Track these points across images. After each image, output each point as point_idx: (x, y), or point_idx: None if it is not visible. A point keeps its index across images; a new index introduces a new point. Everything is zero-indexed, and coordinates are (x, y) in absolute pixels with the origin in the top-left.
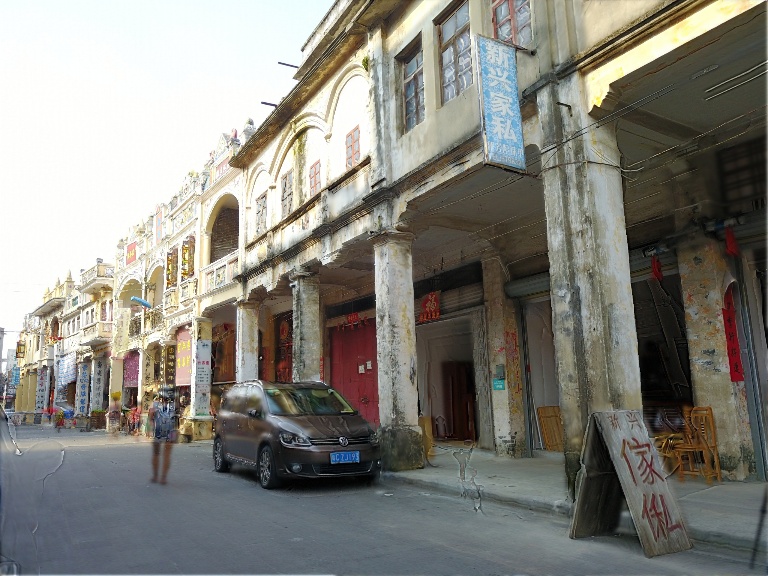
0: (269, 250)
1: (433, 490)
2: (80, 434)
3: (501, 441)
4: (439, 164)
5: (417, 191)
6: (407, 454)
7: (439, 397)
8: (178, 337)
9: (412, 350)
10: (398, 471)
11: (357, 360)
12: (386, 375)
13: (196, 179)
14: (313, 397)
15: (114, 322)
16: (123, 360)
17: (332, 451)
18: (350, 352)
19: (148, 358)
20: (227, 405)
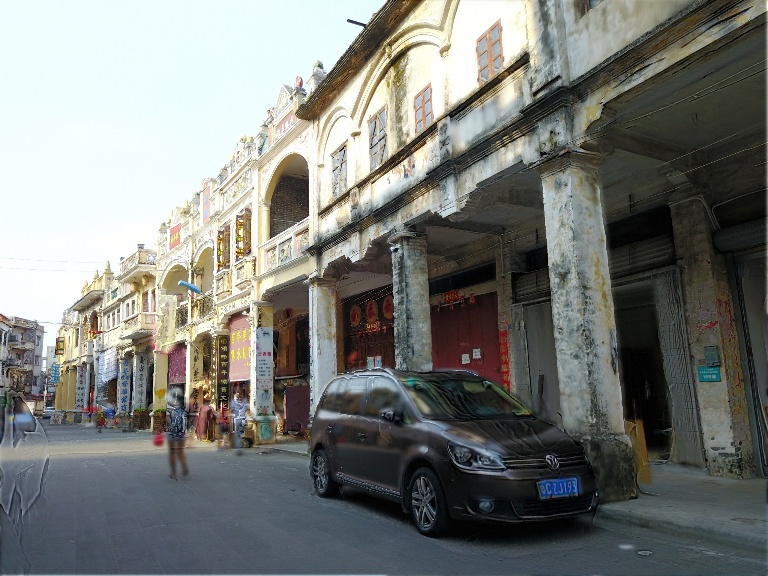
0: (354, 211)
1: (705, 542)
2: (123, 435)
3: (716, 454)
4: (679, 29)
5: (625, 83)
6: (615, 477)
7: None
8: (231, 326)
9: (610, 323)
10: (605, 503)
11: (458, 348)
12: (575, 359)
13: (250, 144)
14: (466, 392)
15: (157, 313)
16: (167, 354)
17: (538, 478)
18: (448, 338)
19: (196, 351)
20: (329, 404)
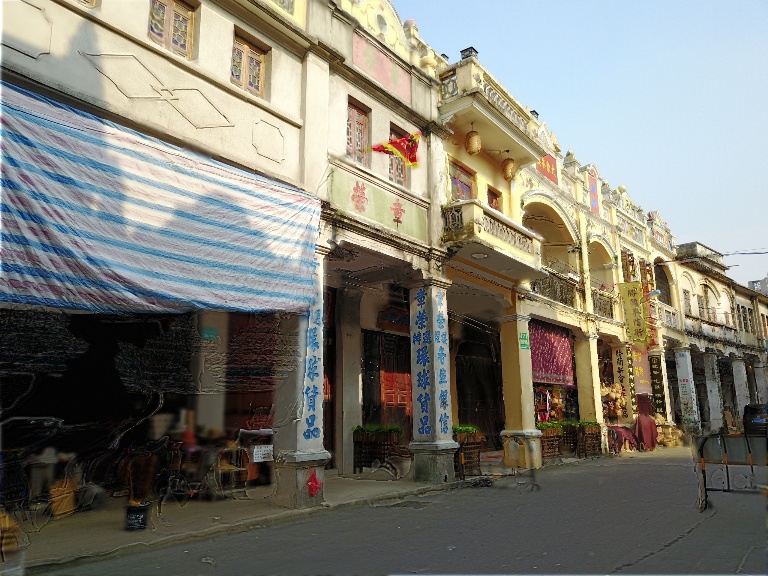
0: None
1: None
2: None
3: None
4: None
5: None
6: None
7: (674, 412)
8: None
9: None
10: None
11: None
12: None
13: None
14: None
15: None
16: None
17: None
18: None
19: None
20: None
